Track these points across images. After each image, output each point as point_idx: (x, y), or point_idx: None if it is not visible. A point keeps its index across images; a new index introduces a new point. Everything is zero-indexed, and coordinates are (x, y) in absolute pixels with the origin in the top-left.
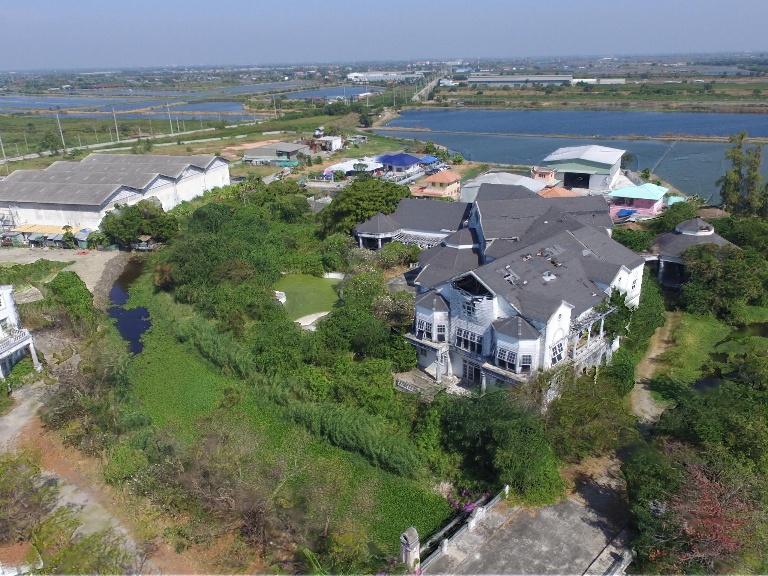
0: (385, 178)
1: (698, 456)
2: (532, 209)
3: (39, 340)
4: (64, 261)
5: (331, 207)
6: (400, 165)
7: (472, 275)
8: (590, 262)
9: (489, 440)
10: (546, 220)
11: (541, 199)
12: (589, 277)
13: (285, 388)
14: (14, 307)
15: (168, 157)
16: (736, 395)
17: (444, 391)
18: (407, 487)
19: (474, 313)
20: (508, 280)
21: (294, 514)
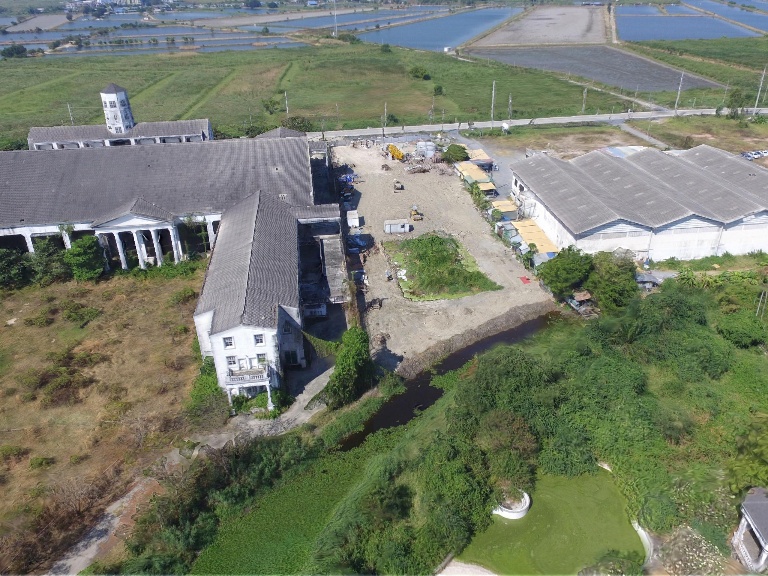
0: None
1: None
2: None
3: (333, 371)
4: (498, 282)
5: (767, 422)
6: None
7: None
8: None
9: None
10: None
11: None
12: None
13: None
14: (275, 347)
15: None
16: None
17: None
18: None
19: None
20: None
21: None
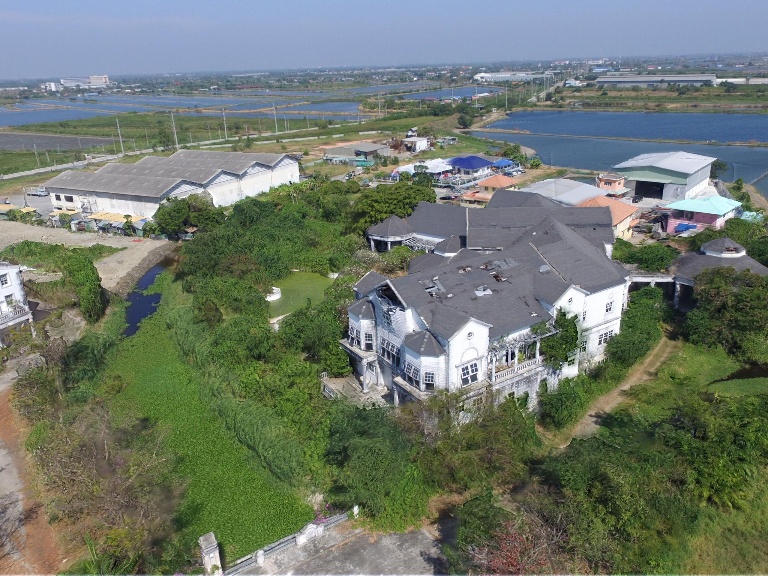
0: (449, 181)
1: (554, 503)
2: (525, 219)
3: None
4: (118, 247)
5: (352, 208)
6: (468, 168)
7: (388, 284)
8: (542, 279)
9: (350, 456)
10: (535, 231)
11: (538, 208)
12: (535, 295)
13: (222, 382)
14: (20, 285)
15: (243, 154)
16: (667, 442)
17: (341, 401)
18: (284, 493)
19: (391, 324)
20: (429, 292)
21: (166, 504)
